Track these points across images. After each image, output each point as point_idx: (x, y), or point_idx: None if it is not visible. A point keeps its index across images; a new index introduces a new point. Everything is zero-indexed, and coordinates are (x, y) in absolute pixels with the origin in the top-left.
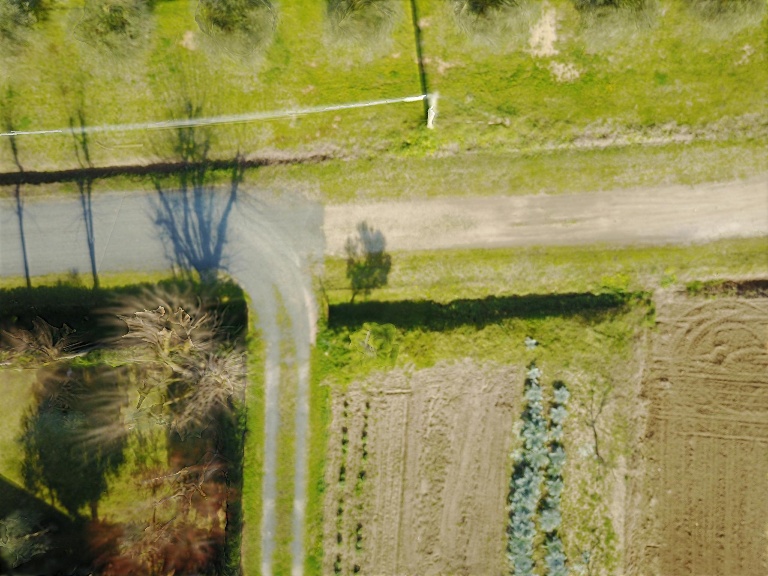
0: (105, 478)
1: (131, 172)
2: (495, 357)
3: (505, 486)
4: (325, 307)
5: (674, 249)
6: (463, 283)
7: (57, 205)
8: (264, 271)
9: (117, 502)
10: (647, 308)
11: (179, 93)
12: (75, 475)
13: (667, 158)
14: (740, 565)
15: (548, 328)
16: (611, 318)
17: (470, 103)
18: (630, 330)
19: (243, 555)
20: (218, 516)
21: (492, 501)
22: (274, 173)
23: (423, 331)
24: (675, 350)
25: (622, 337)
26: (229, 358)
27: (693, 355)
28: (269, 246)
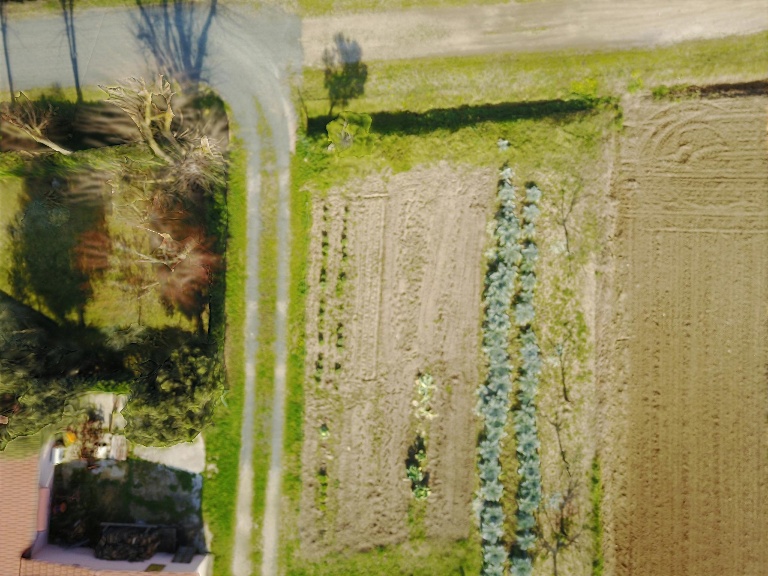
0: (90, 285)
1: None
2: (469, 159)
3: (480, 283)
4: (304, 117)
5: (639, 52)
6: (437, 91)
7: (40, 21)
8: (244, 83)
9: (103, 307)
10: (614, 112)
11: None
12: (61, 282)
13: None
14: (705, 352)
15: (519, 130)
16: (580, 119)
17: None
18: (598, 131)
19: (227, 356)
20: (202, 318)
21: (468, 298)
22: None
23: (399, 136)
24: (642, 152)
25: (591, 137)
26: None
27: (659, 156)
28: (248, 58)
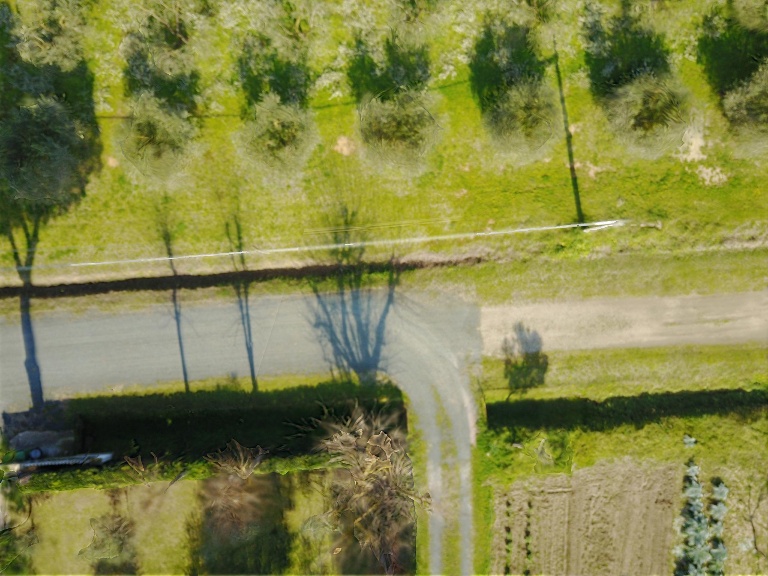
0: None
1: (287, 275)
2: (654, 455)
3: None
4: (483, 407)
5: None
6: (619, 382)
7: (214, 310)
8: (422, 372)
9: None
10: None
11: (335, 198)
12: None
13: None
14: None
15: (706, 426)
16: (766, 415)
17: (622, 206)
18: None
19: None
20: None
21: None
22: (430, 275)
23: (583, 431)
24: None
25: None
26: (403, 466)
27: None
28: (427, 348)
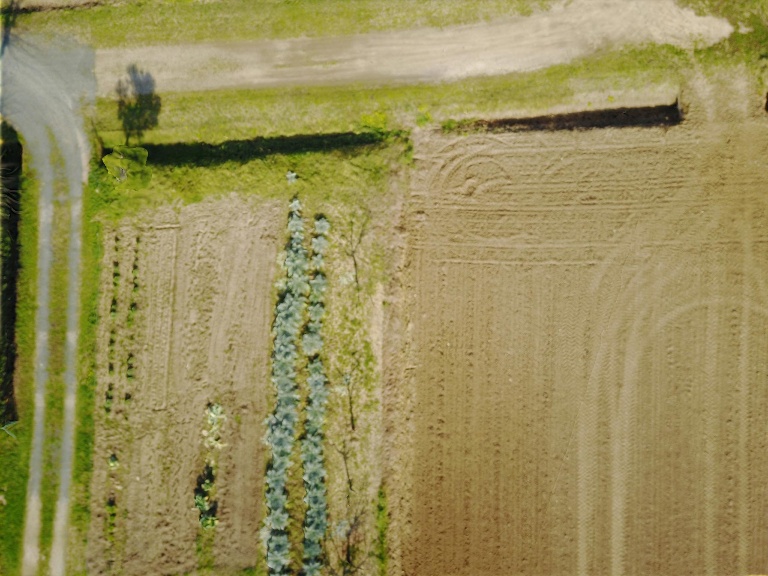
0: None
1: None
2: (259, 191)
3: (269, 314)
4: (98, 148)
5: (426, 87)
6: (230, 123)
7: None
8: (37, 114)
9: None
10: (404, 145)
11: None
12: None
13: (418, 1)
14: (488, 380)
15: (308, 162)
16: (368, 152)
17: None
18: (386, 164)
19: (16, 387)
20: None
21: (257, 328)
22: (47, 19)
23: (190, 167)
24: (431, 184)
25: (378, 170)
26: None
27: (447, 188)
28: (42, 89)
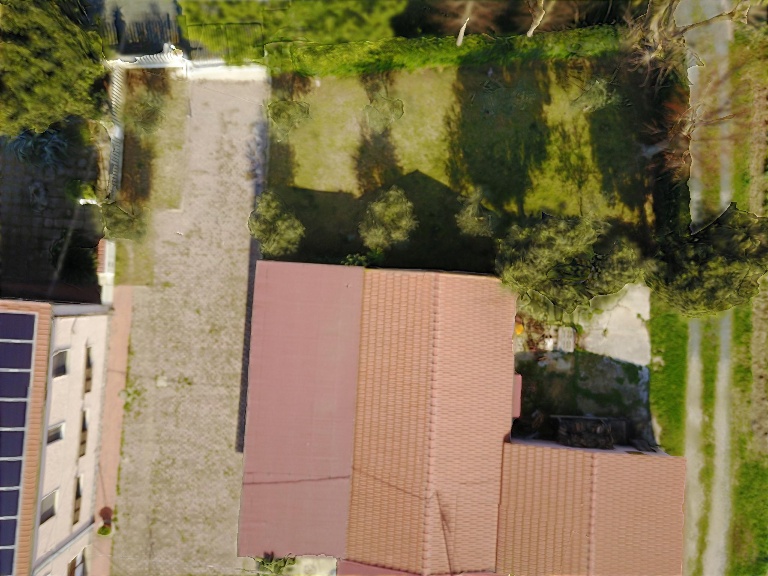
0: (529, 176)
1: None
2: None
3: None
4: None
5: None
6: None
7: None
8: None
9: (542, 199)
10: None
11: None
12: (499, 173)
13: None
14: None
15: None
16: None
17: None
18: None
19: None
20: (645, 209)
21: None
22: None
23: None
24: None
25: None
26: None
27: None
28: None
